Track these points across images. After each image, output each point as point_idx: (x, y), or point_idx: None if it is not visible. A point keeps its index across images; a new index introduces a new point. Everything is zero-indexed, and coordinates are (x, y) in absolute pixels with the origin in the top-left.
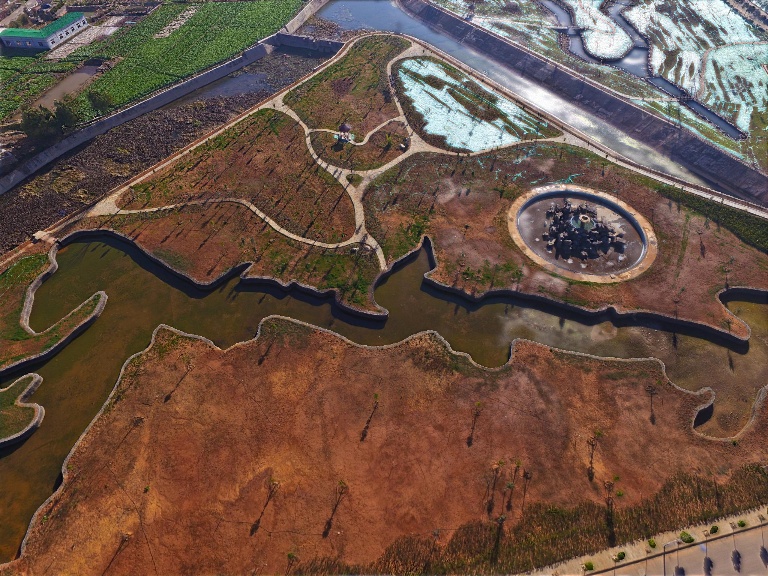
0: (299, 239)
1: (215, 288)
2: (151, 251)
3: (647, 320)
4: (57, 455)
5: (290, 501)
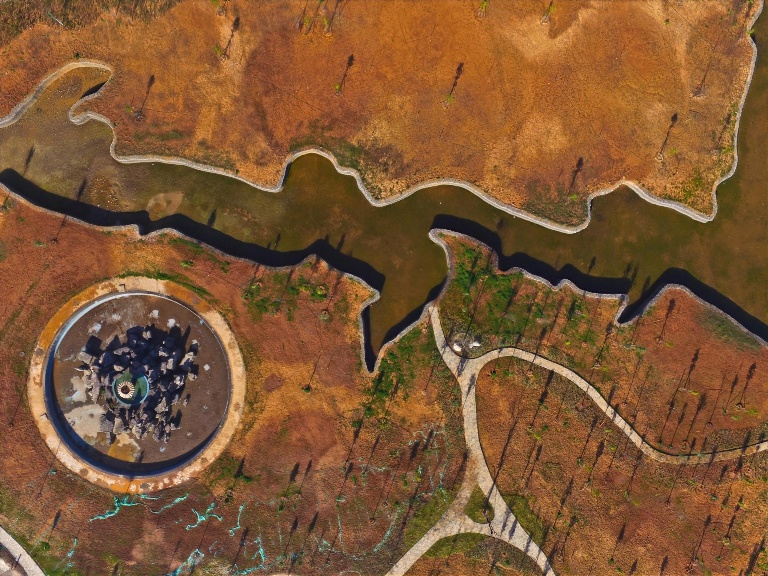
0: (558, 367)
1: (657, 285)
2: (764, 348)
3: (103, 221)
4: (766, 67)
5: (529, 6)
